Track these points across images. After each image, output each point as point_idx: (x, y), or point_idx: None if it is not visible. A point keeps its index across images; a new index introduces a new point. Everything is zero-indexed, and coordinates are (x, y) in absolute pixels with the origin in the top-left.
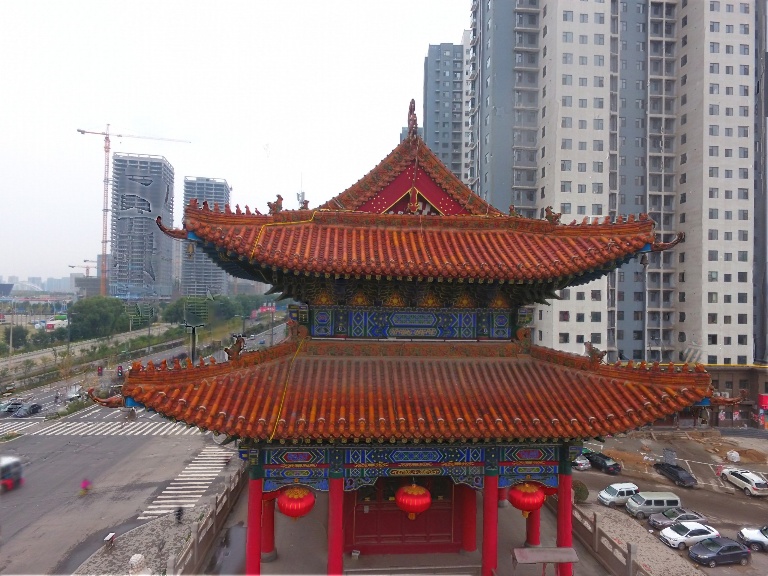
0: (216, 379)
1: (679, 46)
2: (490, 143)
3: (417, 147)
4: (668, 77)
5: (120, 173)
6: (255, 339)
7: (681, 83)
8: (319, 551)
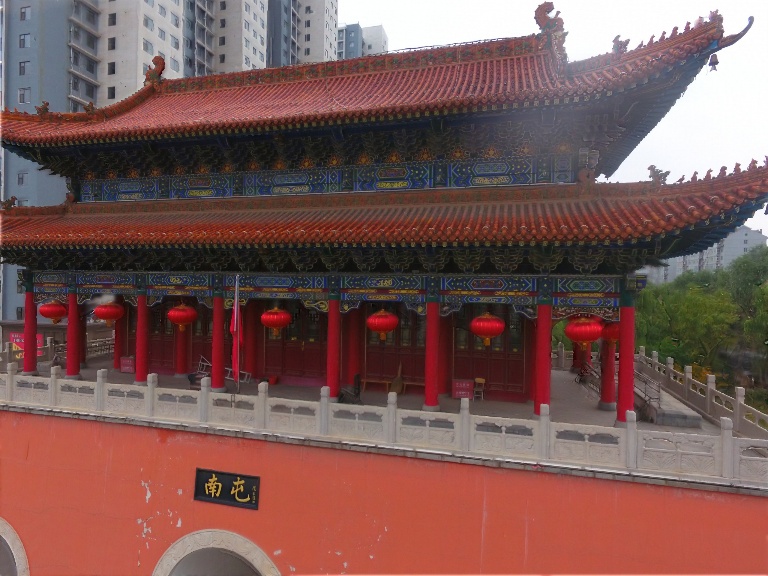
0: None
1: (218, 25)
2: (33, 21)
3: None
4: (209, 49)
5: None
6: None
7: (220, 60)
8: (529, 407)
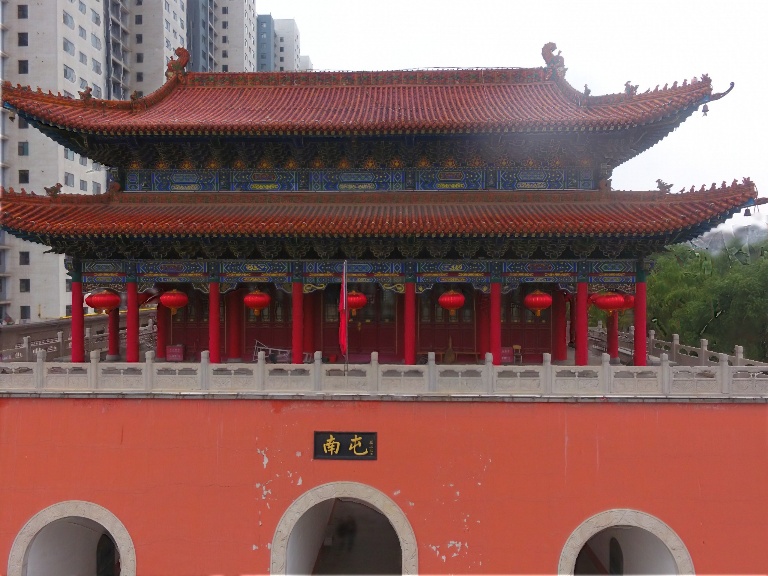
0: None
1: (133, 2)
2: None
3: None
4: (124, 26)
5: None
6: None
7: (137, 40)
8: None
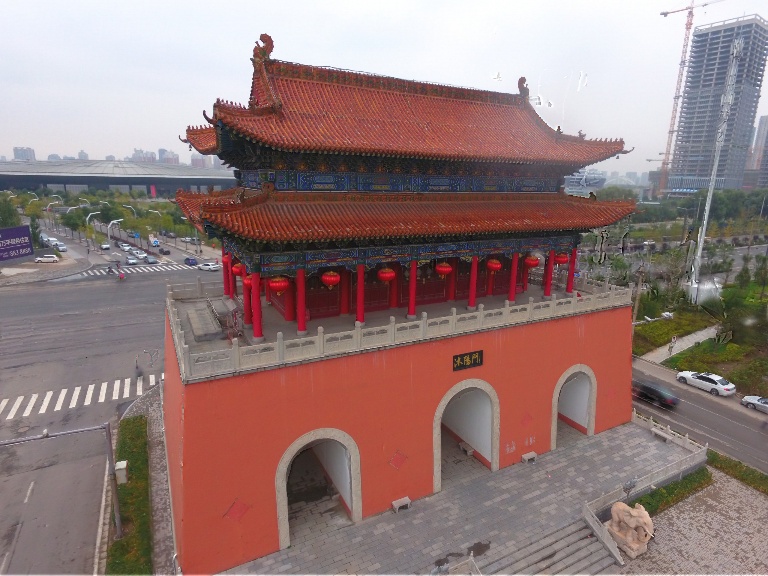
0: None
1: None
2: None
3: None
4: None
5: (539, 72)
6: (617, 228)
7: None
8: None
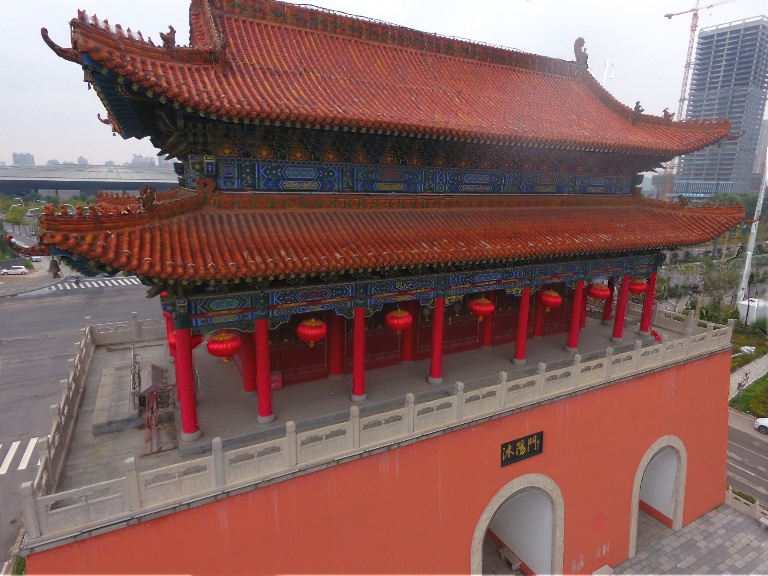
0: (133, 206)
1: None
2: None
3: (193, 0)
4: None
5: None
6: None
7: None
8: None
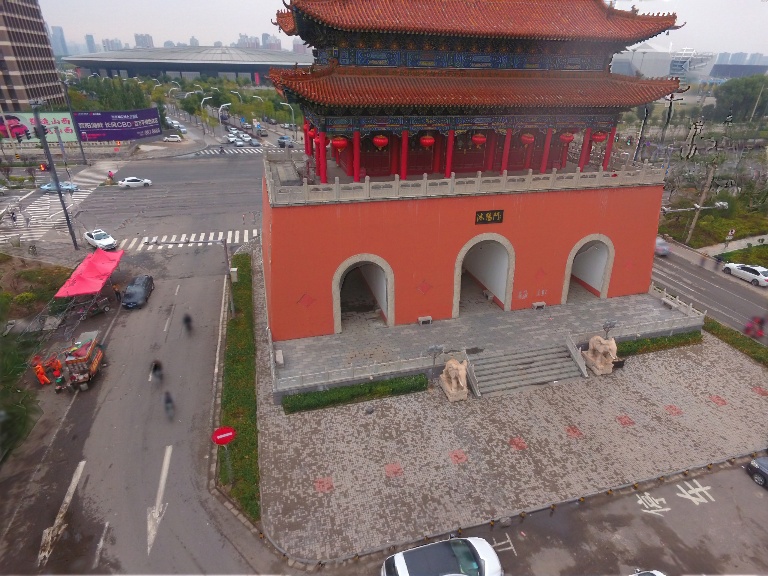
0: None
1: None
2: None
3: None
4: None
5: None
6: None
7: None
8: None
